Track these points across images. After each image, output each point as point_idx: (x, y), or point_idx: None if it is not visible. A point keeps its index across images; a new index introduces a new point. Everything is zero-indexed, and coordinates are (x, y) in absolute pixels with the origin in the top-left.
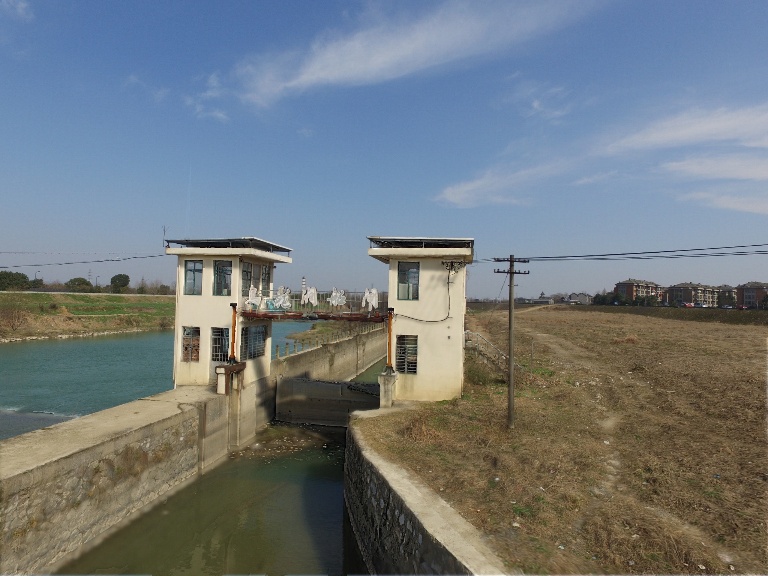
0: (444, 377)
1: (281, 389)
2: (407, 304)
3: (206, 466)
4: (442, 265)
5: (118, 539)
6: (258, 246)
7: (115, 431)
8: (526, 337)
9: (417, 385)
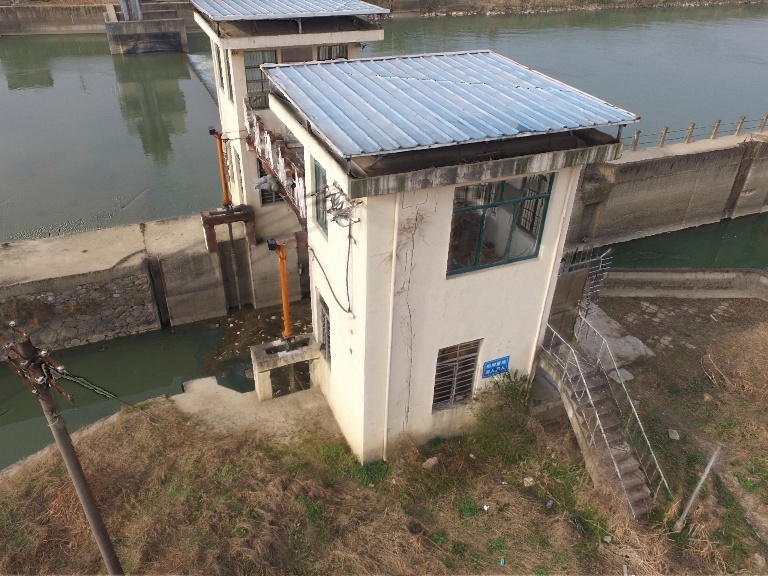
0: (350, 411)
1: None
2: (320, 239)
3: (179, 325)
4: None
5: None
6: None
7: (11, 277)
8: None
9: (332, 389)
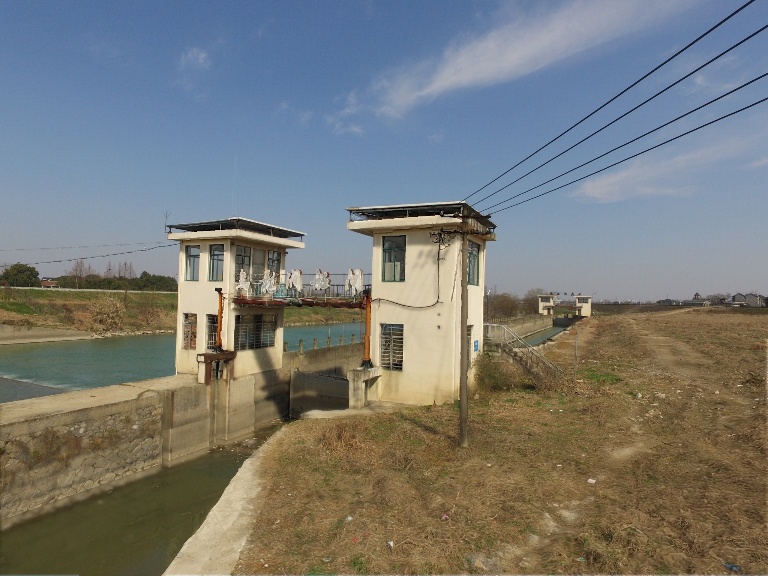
0: (433, 376)
1: (294, 383)
2: (392, 286)
3: (175, 458)
4: (431, 238)
5: (36, 526)
6: (260, 229)
7: (42, 413)
8: (633, 340)
9: (402, 384)
